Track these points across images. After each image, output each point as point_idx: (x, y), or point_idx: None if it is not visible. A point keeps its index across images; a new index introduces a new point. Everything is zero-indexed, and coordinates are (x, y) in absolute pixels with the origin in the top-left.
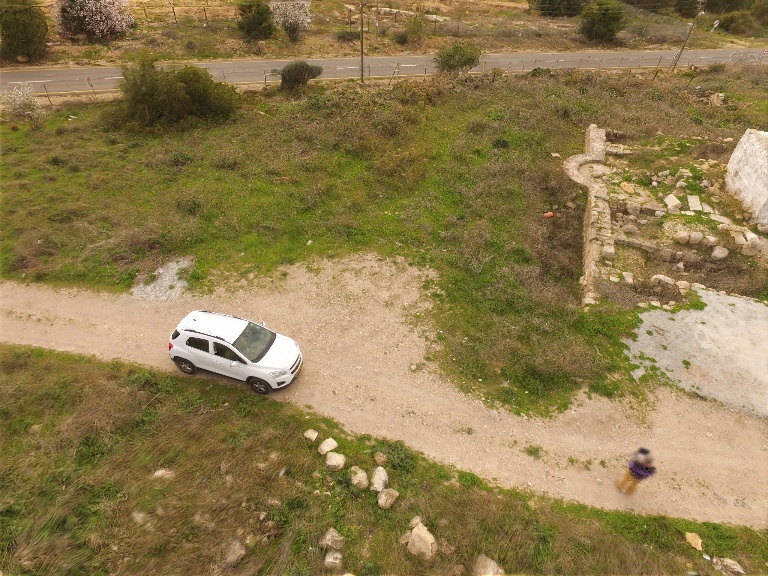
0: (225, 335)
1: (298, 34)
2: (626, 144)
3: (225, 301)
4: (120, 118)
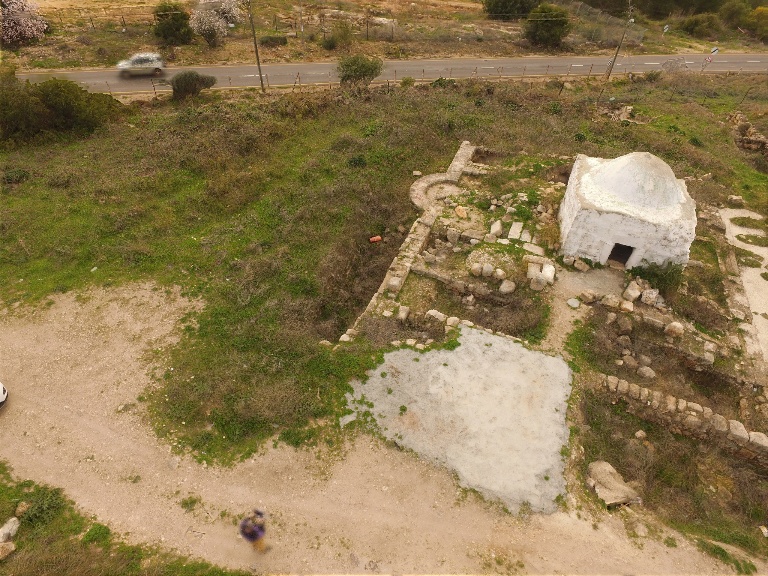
0: None
1: (217, 40)
2: None
3: None
4: None
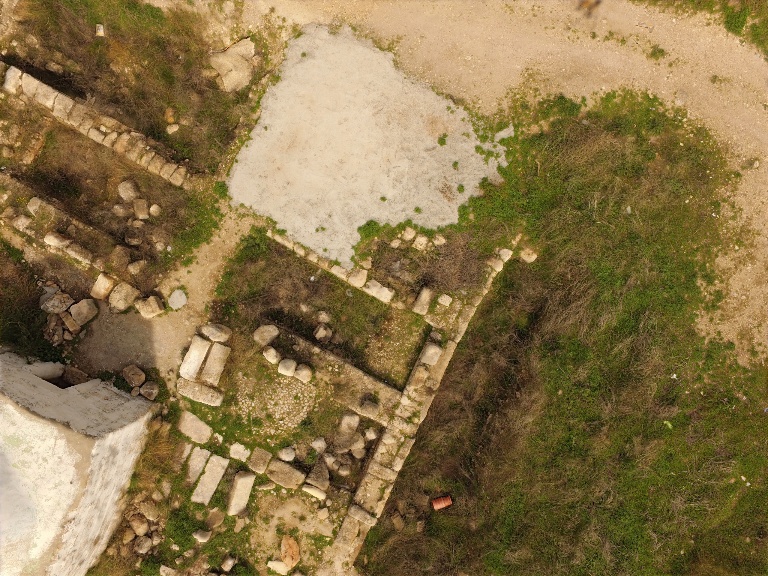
0: None
1: None
2: None
3: None
4: None
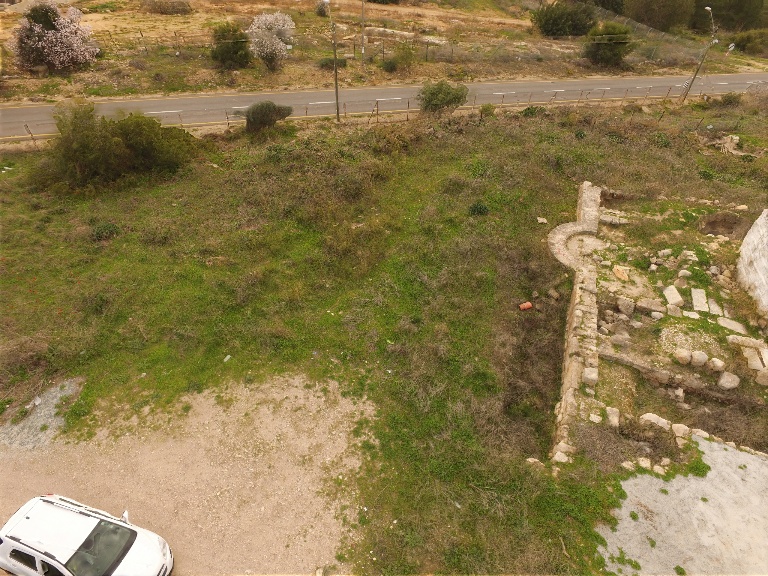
0: (60, 547)
1: (276, 63)
2: (624, 206)
3: (104, 452)
4: (50, 176)
